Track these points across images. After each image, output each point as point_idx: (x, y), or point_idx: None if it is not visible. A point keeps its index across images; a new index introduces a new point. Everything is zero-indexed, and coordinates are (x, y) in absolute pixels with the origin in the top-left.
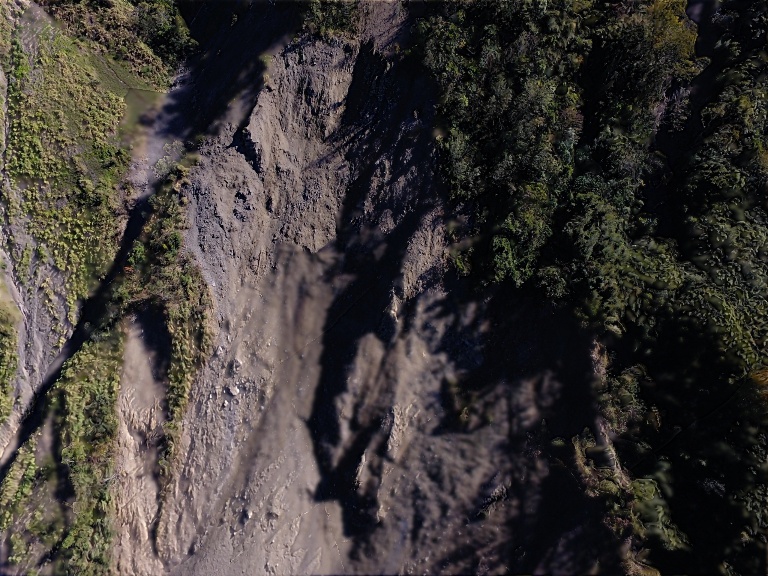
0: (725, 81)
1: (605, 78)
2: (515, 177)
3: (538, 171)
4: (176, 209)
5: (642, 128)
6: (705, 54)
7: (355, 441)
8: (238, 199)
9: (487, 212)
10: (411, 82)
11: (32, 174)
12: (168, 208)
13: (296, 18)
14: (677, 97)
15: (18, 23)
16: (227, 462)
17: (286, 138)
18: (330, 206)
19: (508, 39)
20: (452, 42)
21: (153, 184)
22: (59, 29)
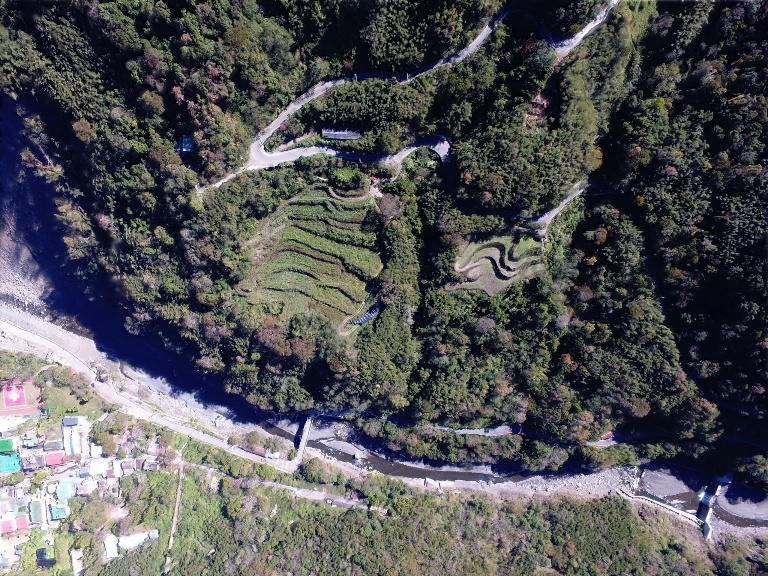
0: None
1: None
2: None
3: None
4: None
5: None
6: None
7: None
8: None
9: None
10: None
11: None
12: None
13: None
14: None
15: None
16: None
17: None
18: None
19: None
20: None
21: None
22: None
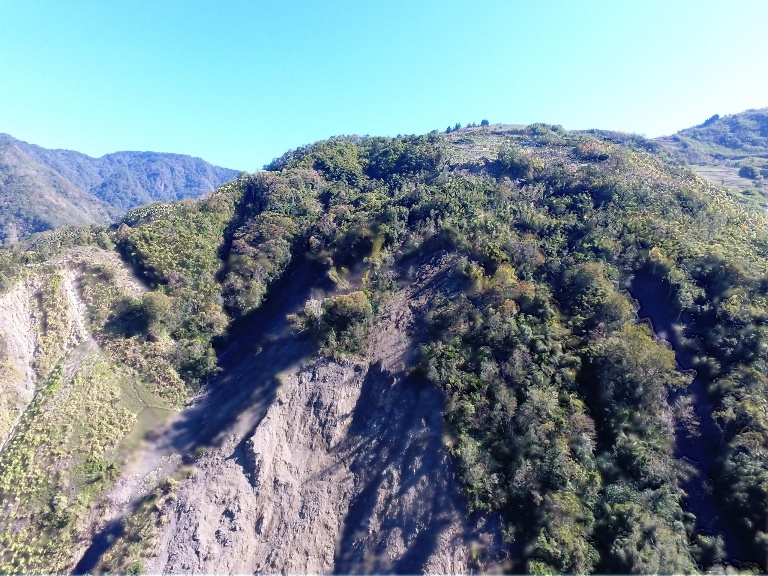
0: (720, 389)
1: (603, 388)
2: (538, 484)
3: (562, 477)
4: (150, 530)
5: (658, 433)
6: None
7: None
8: (225, 517)
9: (514, 528)
10: (417, 394)
11: (7, 489)
12: (141, 529)
13: (313, 346)
14: (680, 405)
15: (69, 352)
16: None
17: (290, 449)
18: (329, 525)
19: (503, 359)
20: (453, 360)
21: (134, 501)
22: (103, 357)
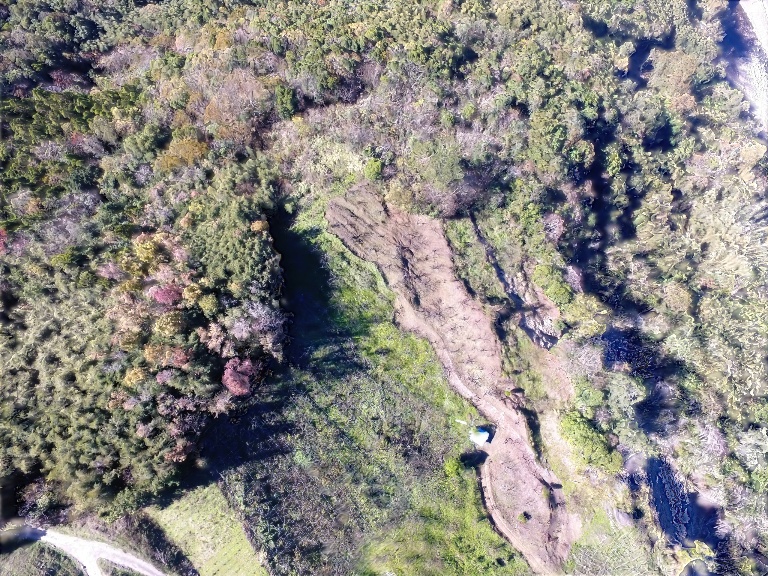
0: None
1: None
2: None
3: None
4: None
5: None
6: None
7: None
8: None
9: None
10: None
11: None
12: None
13: None
14: None
15: None
16: None
17: None
18: None
19: None
20: (763, 165)
21: None
22: None
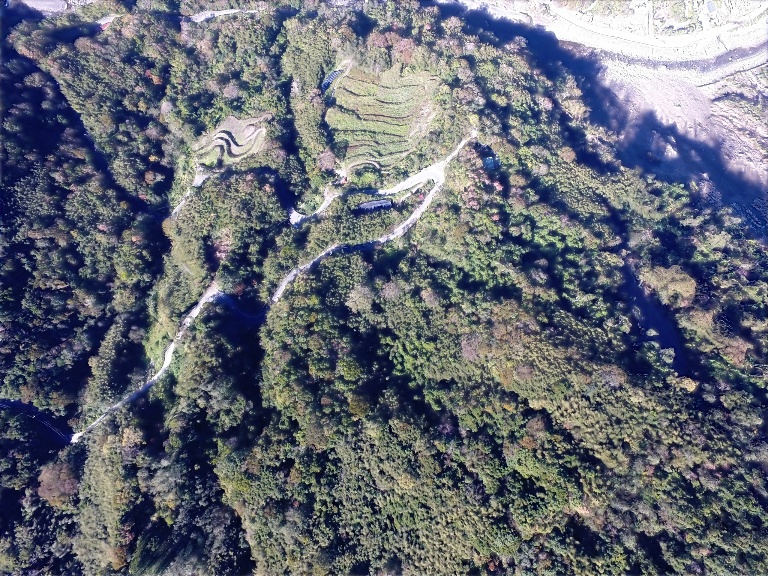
0: None
1: None
2: None
3: None
4: None
5: None
6: (632, 303)
7: (680, 147)
8: None
9: None
10: None
11: None
12: None
13: None
14: None
15: None
16: (721, 139)
17: None
18: (767, 214)
19: None
20: None
21: None
22: None
